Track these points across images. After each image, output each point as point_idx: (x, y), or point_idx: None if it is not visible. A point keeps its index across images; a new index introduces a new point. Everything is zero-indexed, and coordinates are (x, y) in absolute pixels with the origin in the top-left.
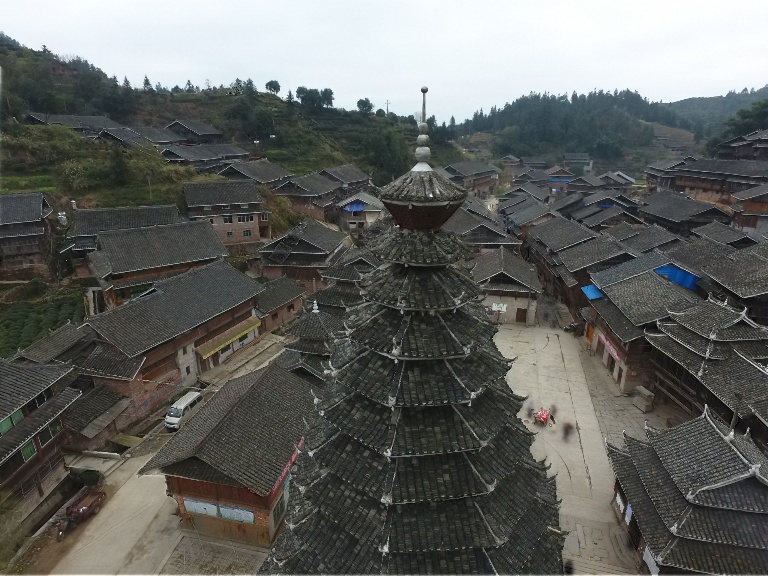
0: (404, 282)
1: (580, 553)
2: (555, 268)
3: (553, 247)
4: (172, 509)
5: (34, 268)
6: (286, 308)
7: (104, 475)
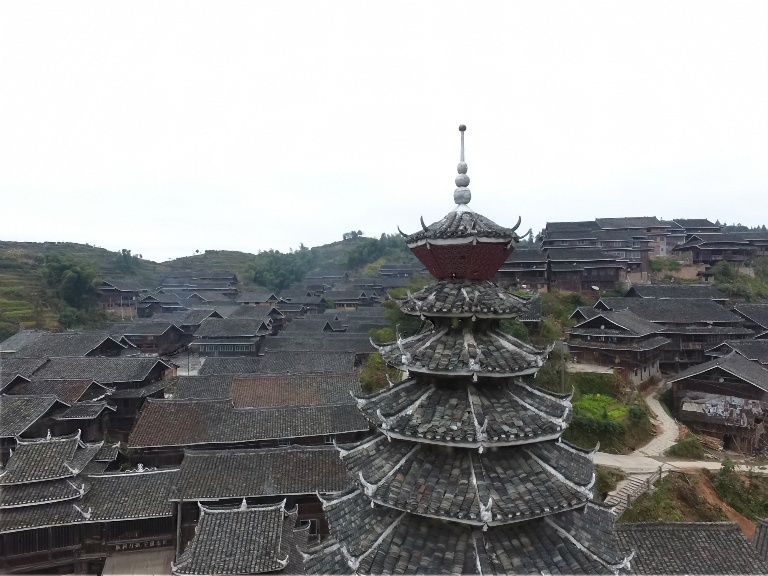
0: (515, 339)
1: None
2: None
3: None
4: None
5: None
6: None
7: None
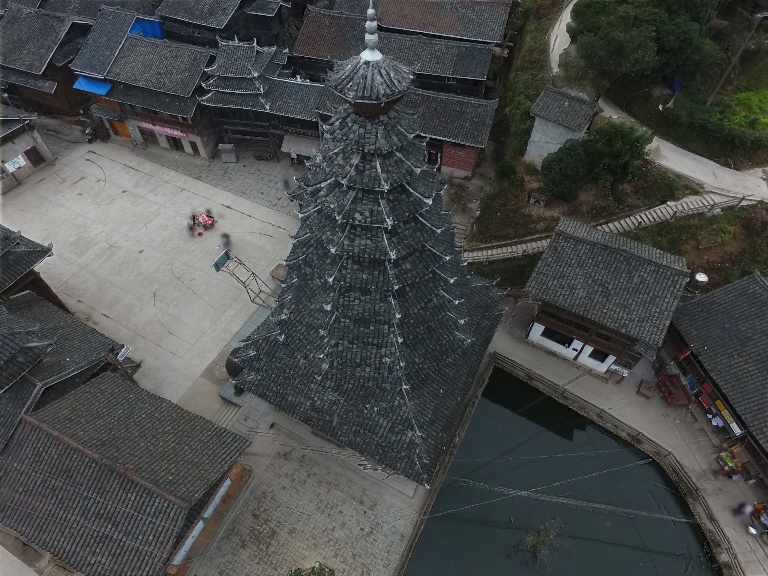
0: (400, 156)
1: None
2: None
3: None
4: None
5: None
6: None
7: None
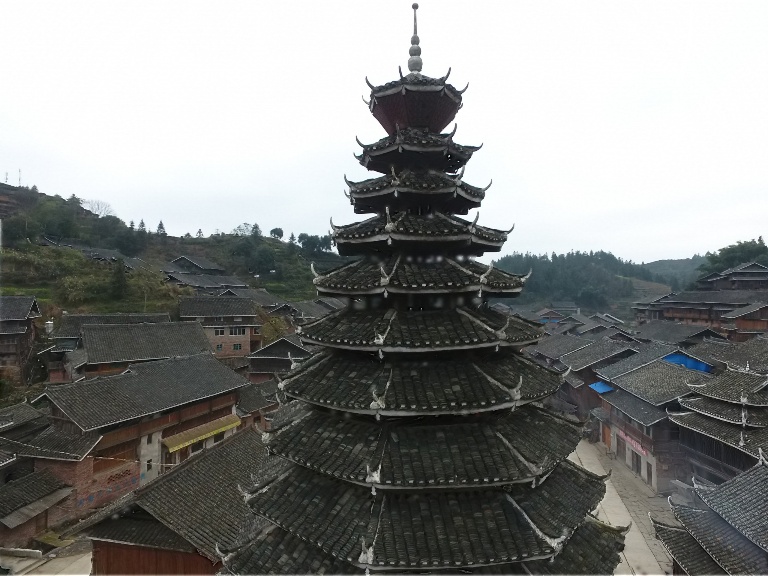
0: None
1: None
2: None
3: (553, 356)
4: None
5: (5, 370)
6: None
7: None
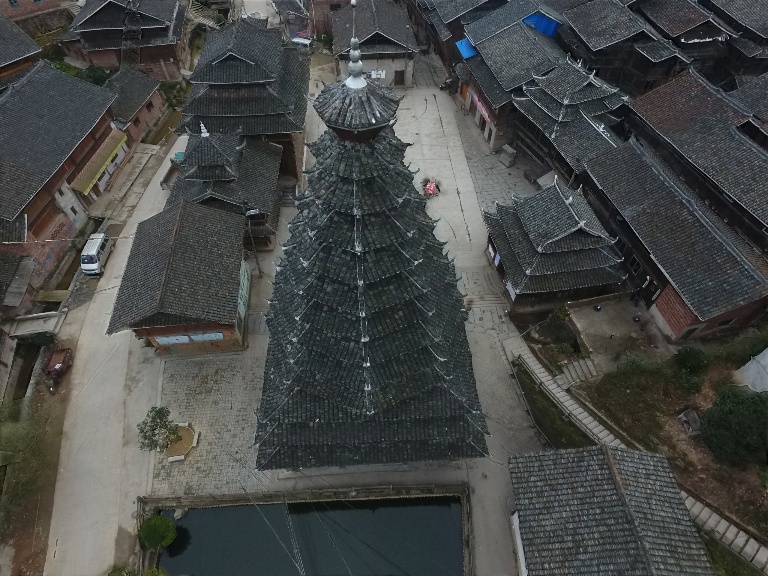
0: (354, 189)
1: (466, 292)
2: (427, 12)
3: None
4: (141, 343)
5: None
6: (145, 108)
7: (54, 333)
